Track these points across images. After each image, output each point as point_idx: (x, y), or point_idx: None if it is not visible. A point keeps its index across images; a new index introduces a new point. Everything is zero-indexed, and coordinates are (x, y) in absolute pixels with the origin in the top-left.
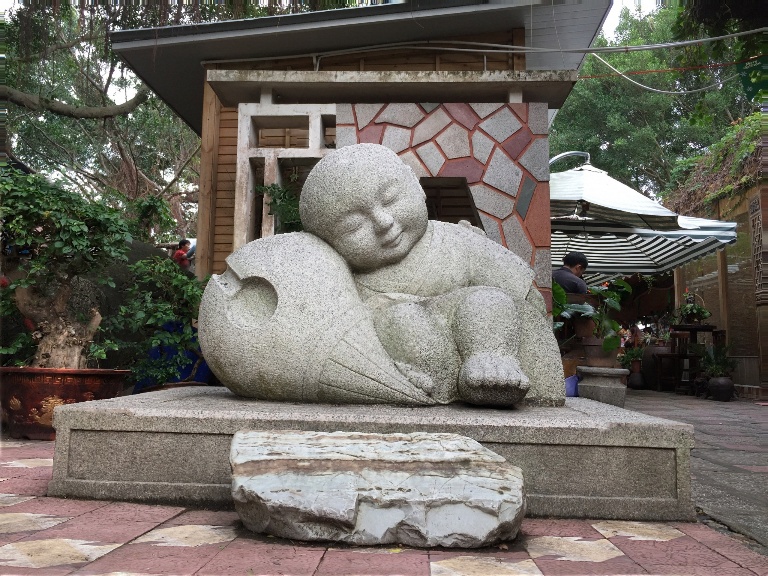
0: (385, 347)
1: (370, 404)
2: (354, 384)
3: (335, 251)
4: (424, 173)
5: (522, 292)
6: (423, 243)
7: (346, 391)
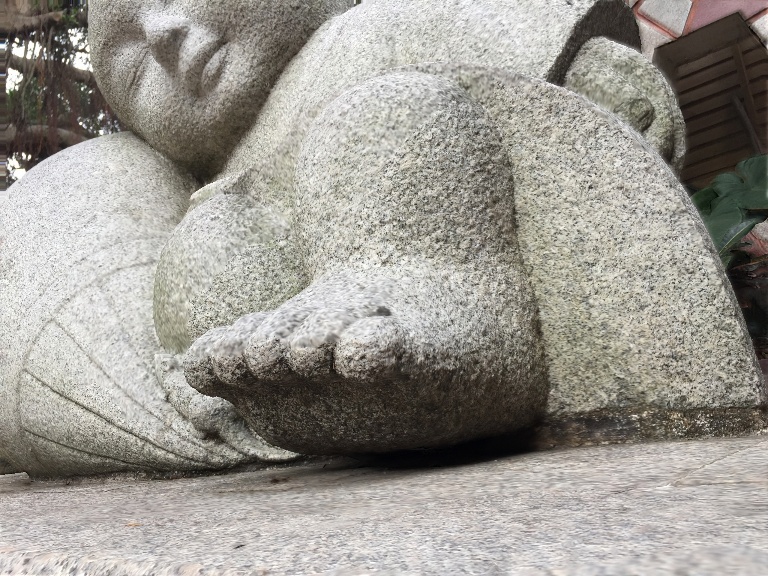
0: (154, 320)
1: (107, 475)
2: (59, 426)
3: (146, 146)
4: (659, 40)
5: (535, 61)
6: (303, 58)
7: (56, 445)
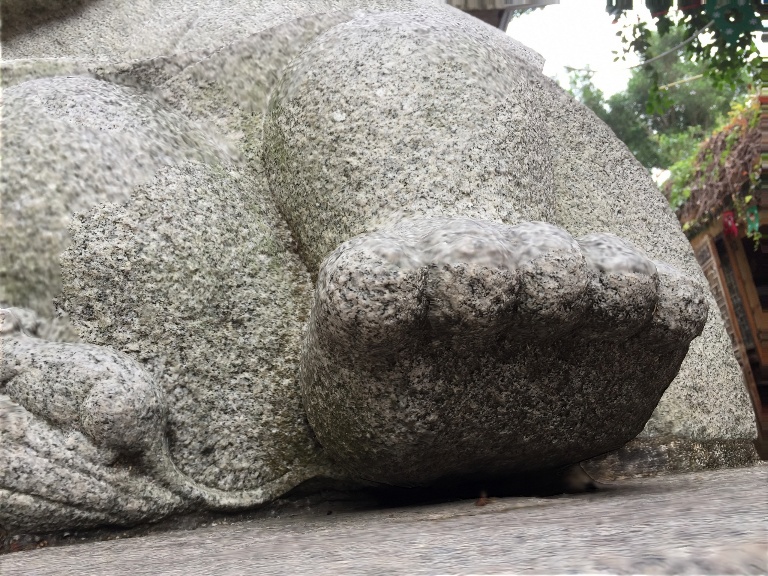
0: None
1: None
2: None
3: None
4: None
5: None
6: None
7: None
